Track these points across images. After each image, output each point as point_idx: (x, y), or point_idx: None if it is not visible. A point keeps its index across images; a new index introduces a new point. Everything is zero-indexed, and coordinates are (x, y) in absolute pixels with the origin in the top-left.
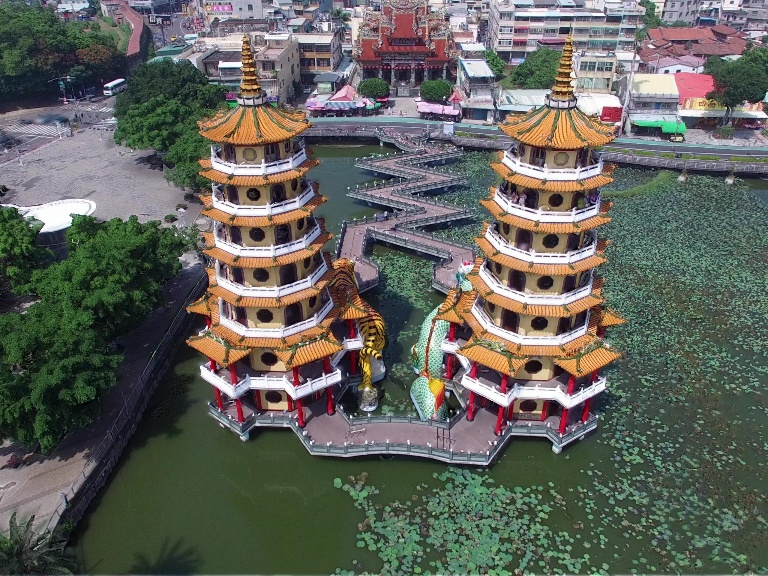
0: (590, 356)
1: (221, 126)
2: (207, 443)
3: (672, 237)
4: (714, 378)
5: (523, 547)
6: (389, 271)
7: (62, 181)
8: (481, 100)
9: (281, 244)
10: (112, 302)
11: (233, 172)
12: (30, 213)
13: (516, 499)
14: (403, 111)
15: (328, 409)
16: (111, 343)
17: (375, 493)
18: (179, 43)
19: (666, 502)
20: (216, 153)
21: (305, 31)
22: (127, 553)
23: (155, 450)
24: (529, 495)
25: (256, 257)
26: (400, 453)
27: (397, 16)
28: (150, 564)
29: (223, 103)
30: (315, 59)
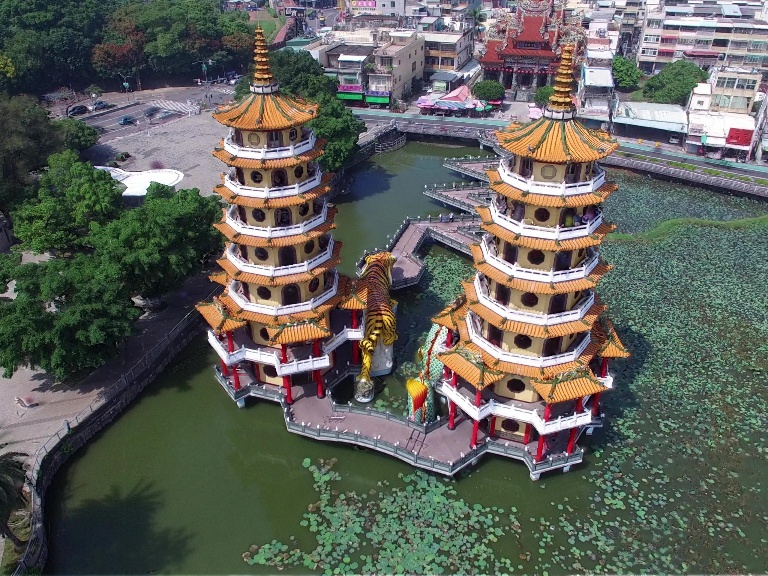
0: (570, 384)
1: (233, 110)
2: (211, 403)
3: (764, 278)
4: (748, 437)
5: (458, 563)
6: (437, 272)
7: (176, 153)
8: (596, 110)
9: (279, 227)
10: (146, 262)
11: (237, 154)
12: (130, 178)
13: (471, 516)
14: (513, 116)
15: (318, 392)
16: (154, 300)
17: (337, 479)
18: (309, 35)
19: (632, 555)
20: (232, 135)
21: (435, 29)
22: (106, 483)
23: (164, 400)
24: (486, 515)
25: (254, 236)
26: (367, 446)
27: (526, 18)
28: (120, 497)
29: (320, 93)
30: (439, 58)
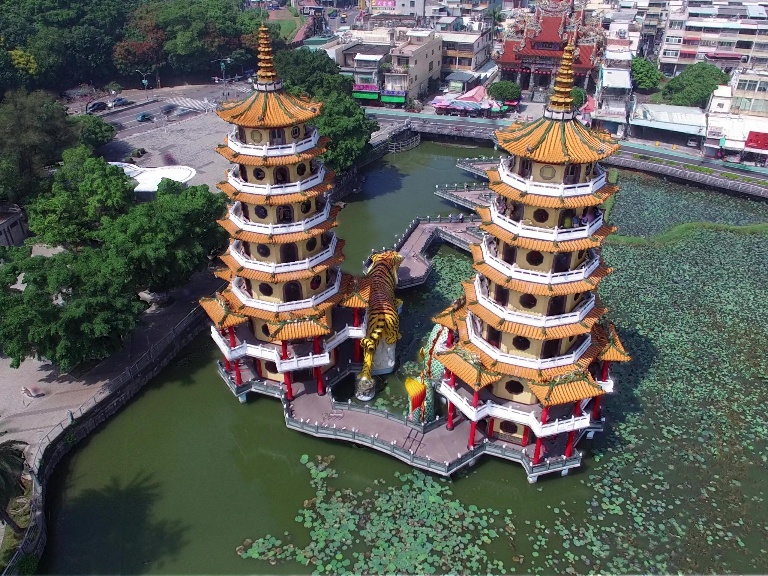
0: (567, 387)
1: (237, 108)
2: (214, 398)
3: None
4: (752, 446)
5: (450, 564)
6: (445, 272)
7: (191, 150)
8: (613, 112)
9: (280, 224)
10: (153, 256)
11: (240, 151)
12: (144, 174)
13: (466, 516)
14: (529, 116)
15: (318, 389)
16: (162, 294)
17: (333, 476)
18: (326, 34)
19: (627, 561)
20: (236, 132)
21: (454, 29)
22: (107, 474)
23: (167, 394)
24: (481, 516)
25: (256, 233)
26: (364, 444)
27: (545, 19)
28: (120, 488)
29: (333, 92)
30: (457, 58)
